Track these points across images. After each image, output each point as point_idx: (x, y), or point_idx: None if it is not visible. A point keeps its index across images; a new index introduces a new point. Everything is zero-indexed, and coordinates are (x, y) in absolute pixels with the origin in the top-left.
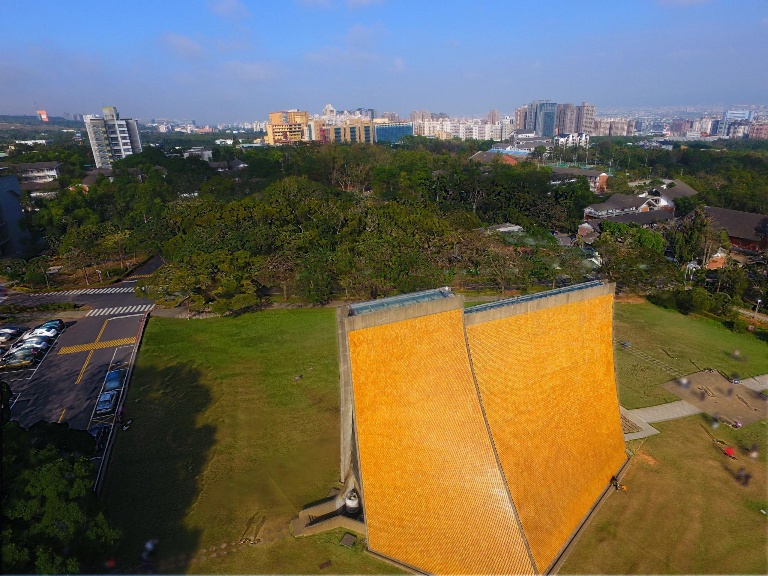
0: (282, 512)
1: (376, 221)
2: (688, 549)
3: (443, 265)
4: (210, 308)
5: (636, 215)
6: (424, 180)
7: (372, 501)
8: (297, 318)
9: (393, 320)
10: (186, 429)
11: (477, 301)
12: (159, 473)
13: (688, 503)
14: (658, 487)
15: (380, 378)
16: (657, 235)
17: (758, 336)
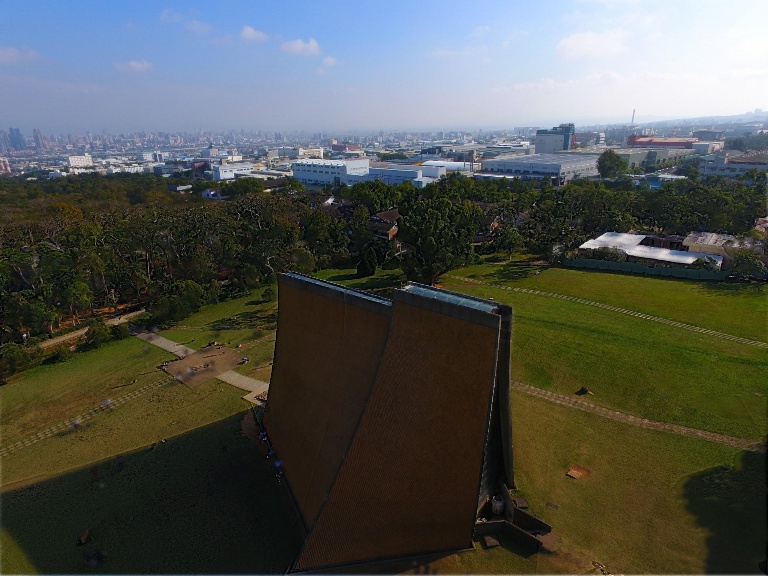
0: (552, 571)
1: None
2: None
3: None
4: None
5: None
6: None
7: None
8: None
9: None
10: None
11: None
12: None
13: None
14: None
15: None
16: None
17: (80, 351)
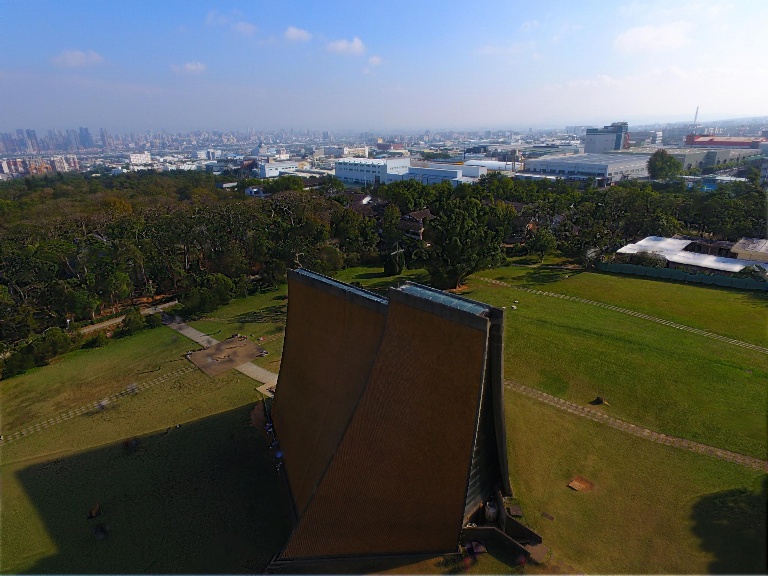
0: None
1: None
2: None
3: None
4: None
5: None
6: None
7: None
8: None
9: None
10: None
11: None
12: None
13: None
14: None
15: None
16: None
17: (116, 338)
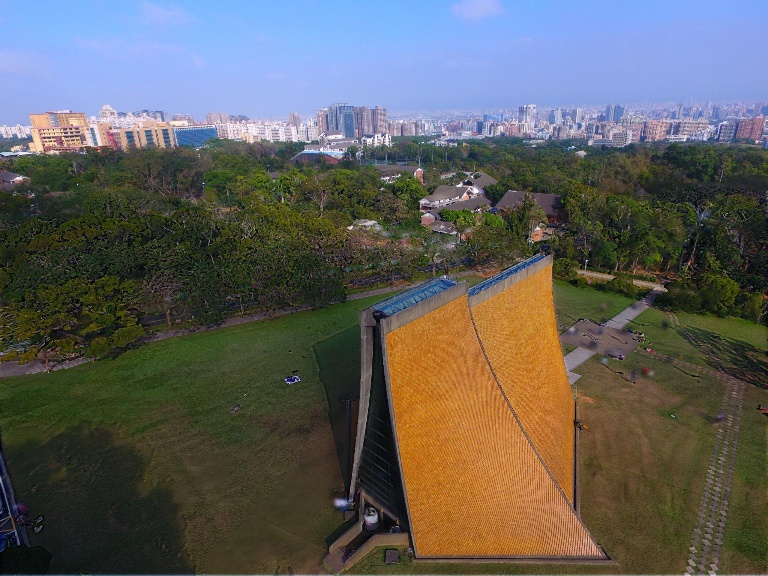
0: (306, 555)
1: (253, 227)
2: (650, 460)
3: (341, 264)
4: (75, 353)
5: (464, 203)
6: (264, 183)
7: (417, 506)
8: (196, 344)
9: (420, 315)
10: (129, 504)
11: (374, 295)
12: (125, 567)
13: (630, 425)
14: (606, 419)
15: (413, 377)
16: (498, 217)
17: (595, 288)
